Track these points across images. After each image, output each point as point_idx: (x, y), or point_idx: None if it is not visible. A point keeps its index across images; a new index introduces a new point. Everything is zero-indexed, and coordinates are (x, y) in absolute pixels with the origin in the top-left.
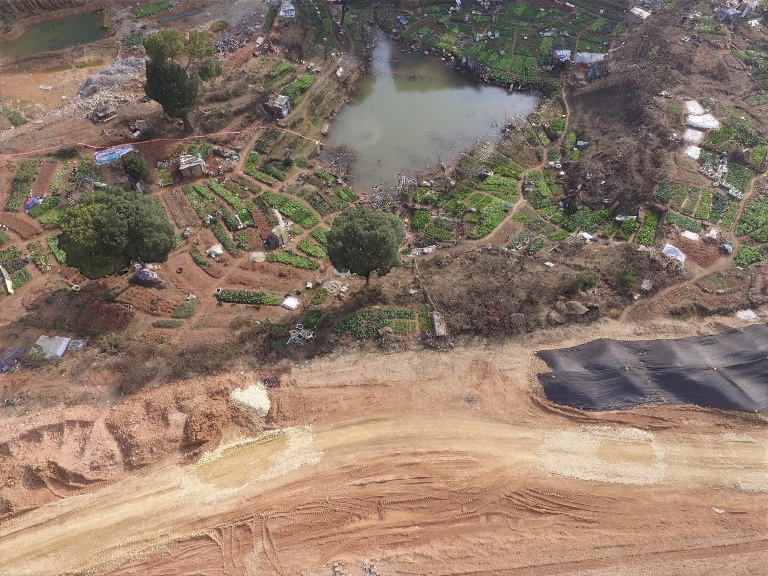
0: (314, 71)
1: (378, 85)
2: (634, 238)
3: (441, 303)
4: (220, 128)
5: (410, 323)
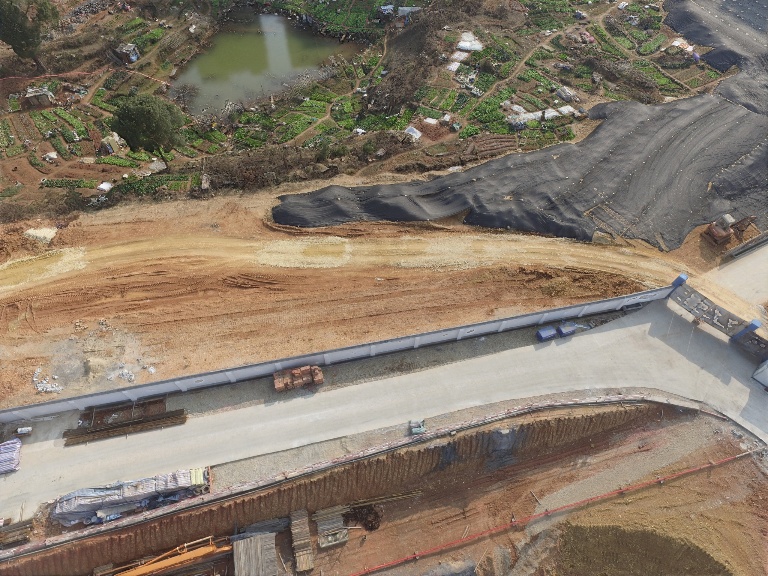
0: (166, 27)
1: (229, 40)
2: None
3: (212, 169)
4: (71, 69)
5: (183, 183)
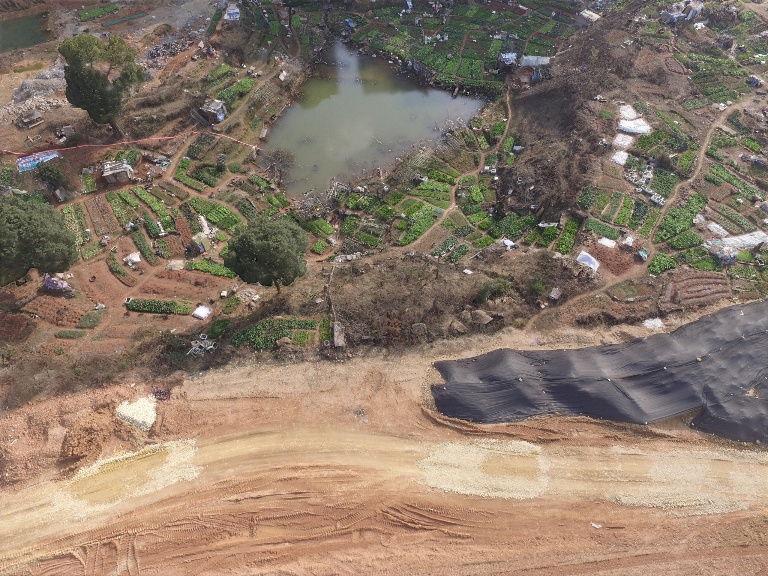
0: (255, 75)
1: None
2: (553, 245)
3: (344, 313)
4: (151, 133)
5: (310, 333)
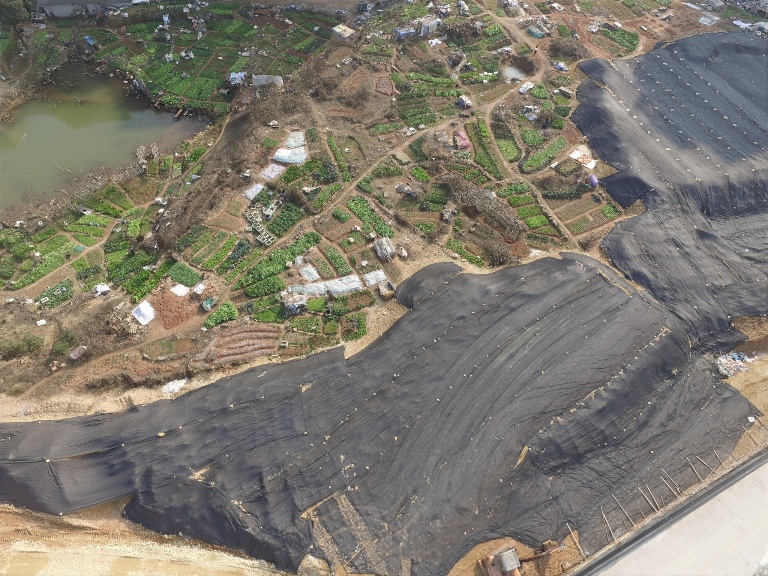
0: None
1: (40, 112)
2: None
3: None
4: None
5: None
